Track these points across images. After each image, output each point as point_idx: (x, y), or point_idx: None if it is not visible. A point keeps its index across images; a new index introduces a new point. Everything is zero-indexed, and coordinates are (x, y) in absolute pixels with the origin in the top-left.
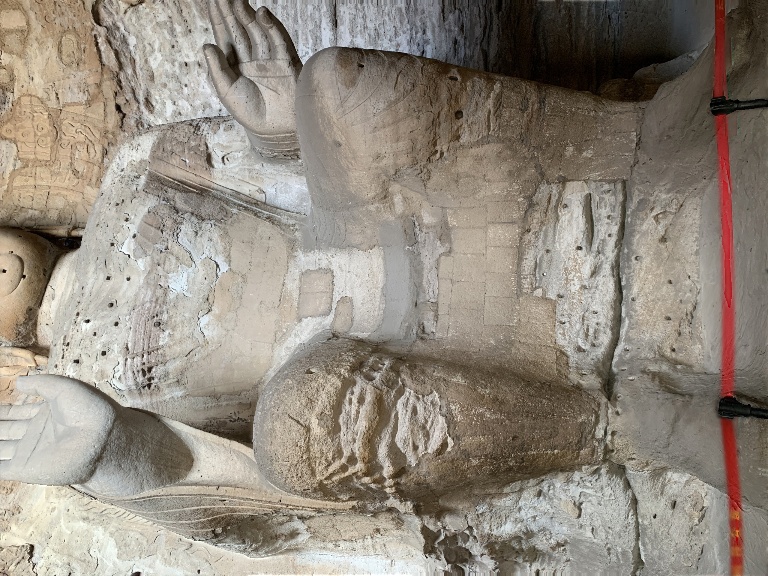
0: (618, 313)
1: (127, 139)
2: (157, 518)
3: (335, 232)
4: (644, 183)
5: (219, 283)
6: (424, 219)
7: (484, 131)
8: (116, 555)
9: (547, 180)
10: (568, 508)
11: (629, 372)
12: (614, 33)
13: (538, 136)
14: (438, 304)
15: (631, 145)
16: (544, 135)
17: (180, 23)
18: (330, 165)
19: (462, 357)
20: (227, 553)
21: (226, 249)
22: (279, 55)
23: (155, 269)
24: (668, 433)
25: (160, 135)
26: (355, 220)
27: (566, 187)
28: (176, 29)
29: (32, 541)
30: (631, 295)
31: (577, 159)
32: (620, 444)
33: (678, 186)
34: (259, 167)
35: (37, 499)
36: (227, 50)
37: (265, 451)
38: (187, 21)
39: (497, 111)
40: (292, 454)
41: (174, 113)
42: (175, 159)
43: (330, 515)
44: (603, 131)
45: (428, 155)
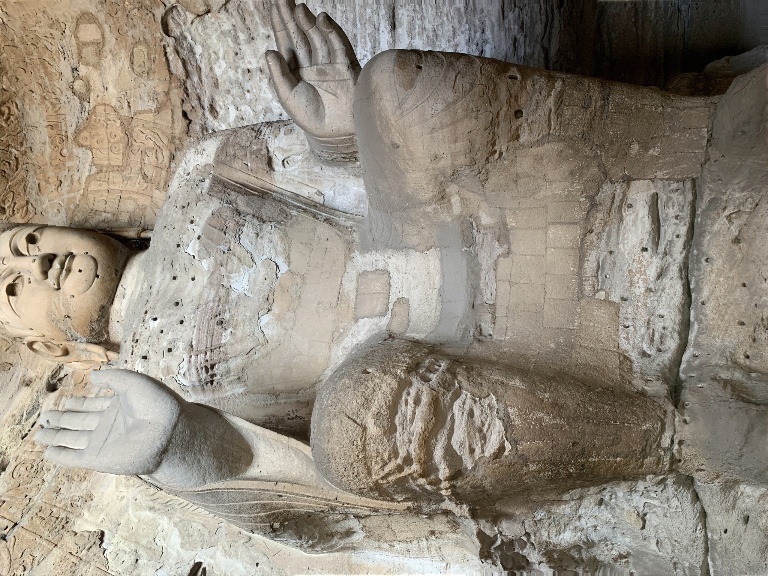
0: (686, 317)
1: (193, 144)
2: (218, 510)
3: (392, 233)
4: (716, 181)
5: (279, 283)
6: (482, 220)
7: (545, 130)
8: (180, 544)
9: (611, 179)
10: (631, 518)
11: (698, 379)
12: (684, 25)
13: (601, 134)
14: (496, 306)
15: (702, 142)
16: (608, 133)
17: (243, 31)
18: (388, 167)
19: (520, 360)
20: (284, 548)
21: (285, 250)
22: (338, 59)
23: (218, 269)
24: (741, 444)
25: (224, 140)
26: (412, 221)
27: (631, 186)
28: (239, 37)
29: (103, 527)
30: (701, 299)
31: (643, 157)
32: (688, 454)
33: (753, 184)
34: (318, 170)
35: (108, 488)
36: (288, 56)
37: (322, 449)
38: (250, 29)
39: (558, 109)
40: (348, 453)
41: (237, 118)
42: (238, 163)
43: (385, 515)
44: (671, 128)
45: (486, 155)
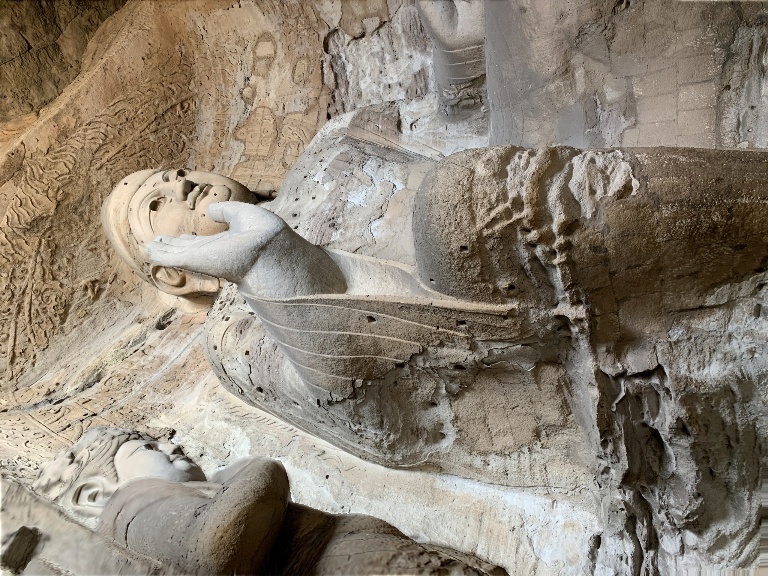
0: None
1: (333, 117)
2: (301, 344)
3: (512, 134)
4: None
5: (394, 197)
6: (607, 96)
7: None
8: (248, 451)
9: (747, 21)
10: None
11: None
12: None
13: None
14: None
15: None
16: None
17: (390, 53)
18: (514, 40)
19: None
20: (360, 463)
21: (404, 176)
22: None
23: (338, 188)
24: None
25: (361, 110)
26: (534, 112)
27: None
28: (386, 58)
29: (176, 427)
30: None
31: None
32: None
33: None
34: (443, 130)
35: (189, 401)
36: None
37: (425, 197)
38: (396, 51)
39: None
40: (453, 192)
41: None
42: (370, 125)
43: (483, 391)
44: None
45: (613, 5)
